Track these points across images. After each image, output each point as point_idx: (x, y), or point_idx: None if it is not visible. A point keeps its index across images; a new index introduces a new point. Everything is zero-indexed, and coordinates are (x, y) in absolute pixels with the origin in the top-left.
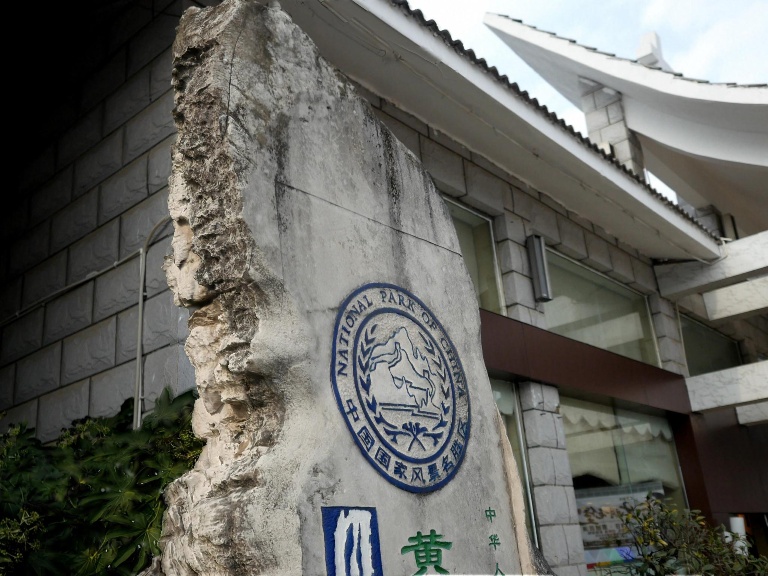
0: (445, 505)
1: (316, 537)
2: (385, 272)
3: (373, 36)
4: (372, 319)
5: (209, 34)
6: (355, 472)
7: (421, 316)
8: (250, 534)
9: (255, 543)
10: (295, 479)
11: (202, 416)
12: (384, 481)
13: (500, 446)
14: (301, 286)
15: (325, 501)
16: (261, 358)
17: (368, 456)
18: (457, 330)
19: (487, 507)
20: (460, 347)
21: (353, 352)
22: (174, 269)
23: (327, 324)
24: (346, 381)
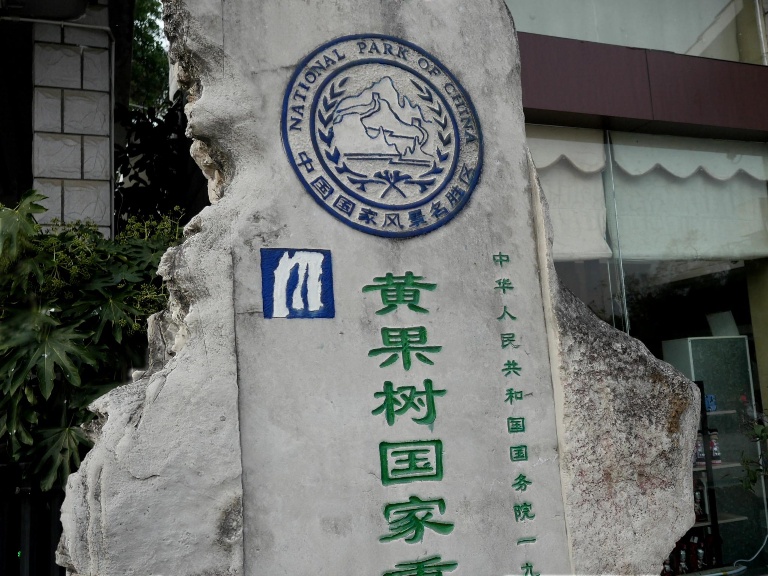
0: (430, 249)
1: (252, 274)
2: (366, 22)
3: None
4: (343, 72)
5: None
6: (305, 218)
7: (417, 63)
8: (185, 271)
9: (190, 278)
10: (233, 225)
11: None
12: (344, 226)
13: (527, 191)
14: (246, 49)
15: (266, 244)
16: (201, 121)
17: (324, 204)
18: (473, 73)
19: (496, 252)
20: (475, 90)
21: (311, 107)
22: None
23: (278, 82)
24: (300, 135)
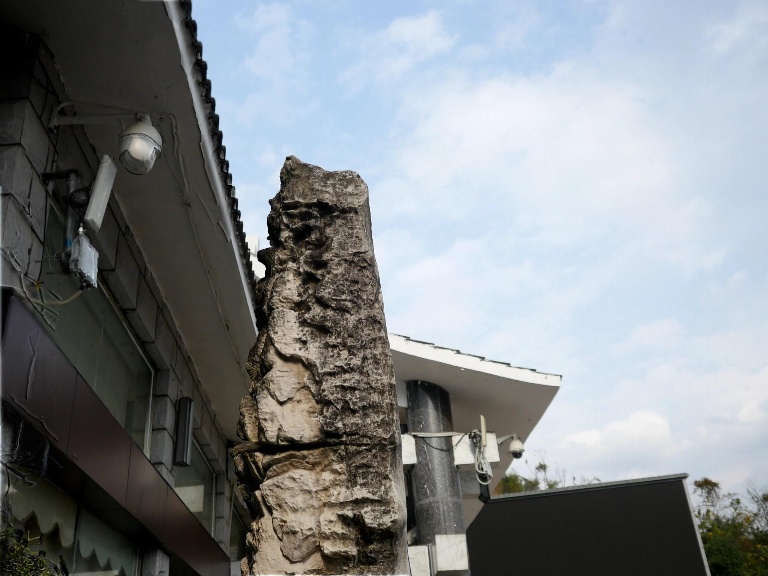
0: None
1: None
2: None
3: (183, 176)
4: None
5: (346, 200)
6: None
7: None
8: None
9: None
10: None
11: (272, 562)
12: None
13: None
14: None
15: None
16: (401, 519)
17: None
18: None
19: None
20: None
21: None
22: (271, 402)
23: None
24: None
